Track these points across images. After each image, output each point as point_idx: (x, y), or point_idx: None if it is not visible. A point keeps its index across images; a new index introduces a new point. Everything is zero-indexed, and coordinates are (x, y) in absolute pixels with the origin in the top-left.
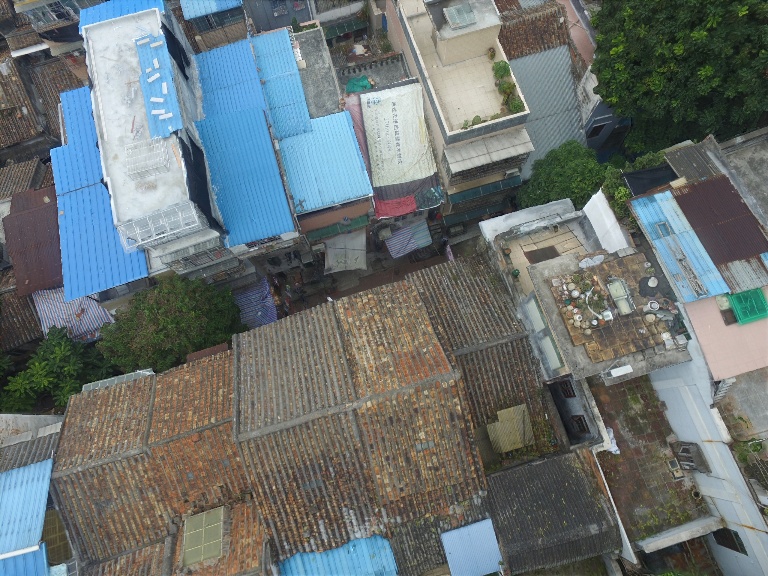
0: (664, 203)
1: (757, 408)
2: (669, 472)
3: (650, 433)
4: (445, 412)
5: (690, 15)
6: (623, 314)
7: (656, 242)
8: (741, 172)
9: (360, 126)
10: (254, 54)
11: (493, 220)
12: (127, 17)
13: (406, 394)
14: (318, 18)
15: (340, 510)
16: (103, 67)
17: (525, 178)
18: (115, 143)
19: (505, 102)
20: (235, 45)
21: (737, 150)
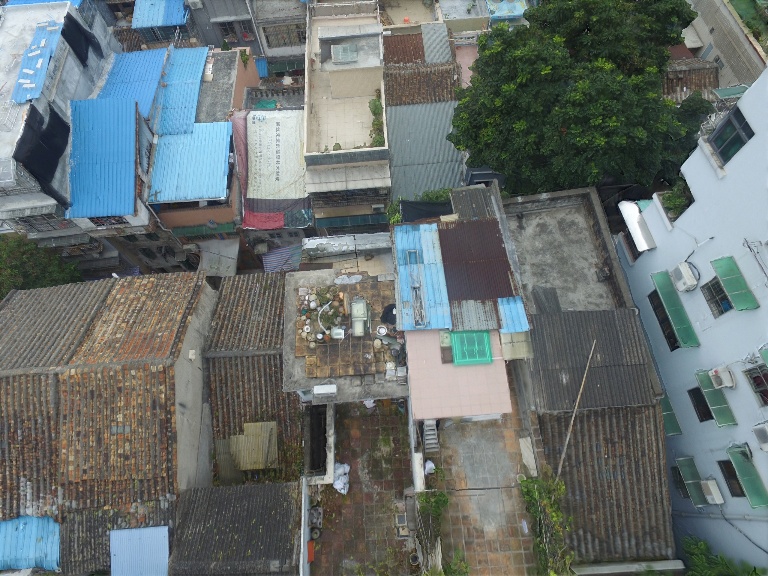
0: (426, 233)
1: (479, 468)
2: (394, 527)
3: (389, 480)
4: (149, 398)
5: (509, 70)
6: (355, 335)
7: (401, 268)
8: (548, 230)
9: (243, 139)
10: (167, 61)
11: (317, 239)
12: (42, 4)
13: (112, 369)
14: (270, 52)
15: (18, 479)
16: (2, 40)
17: None
18: None
19: (371, 137)
20: (153, 51)
21: (551, 209)
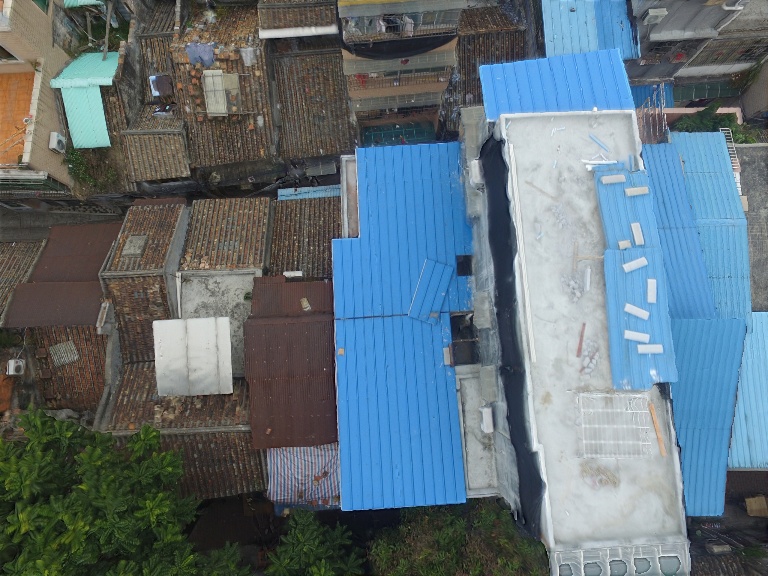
0: None
1: None
2: None
3: None
4: None
5: None
6: None
7: None
8: None
9: None
10: None
11: None
12: (581, 115)
13: None
14: (680, 71)
15: None
16: (531, 205)
17: None
18: (548, 370)
19: None
20: (654, 150)
21: None
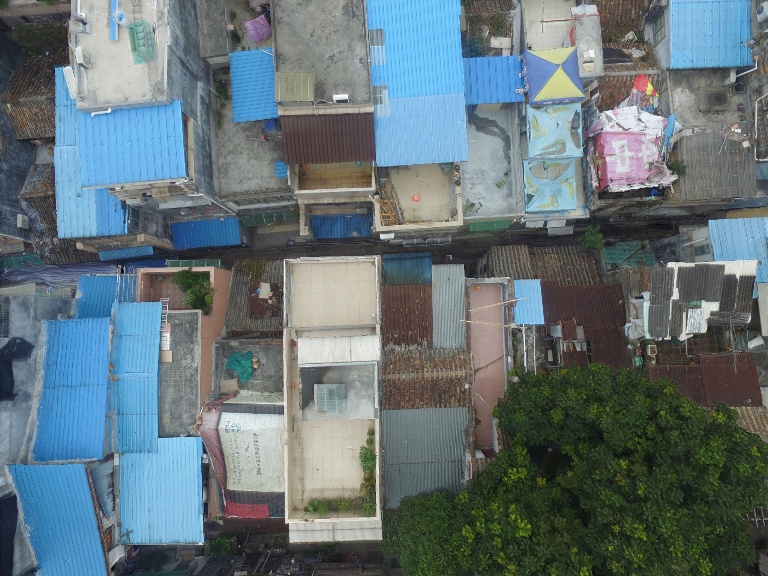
0: None
1: None
2: None
3: None
4: None
5: None
6: None
7: None
8: None
9: (216, 444)
10: (113, 339)
11: None
12: None
13: None
14: (241, 207)
15: None
16: None
17: (391, 507)
18: None
19: None
20: (93, 323)
21: None
